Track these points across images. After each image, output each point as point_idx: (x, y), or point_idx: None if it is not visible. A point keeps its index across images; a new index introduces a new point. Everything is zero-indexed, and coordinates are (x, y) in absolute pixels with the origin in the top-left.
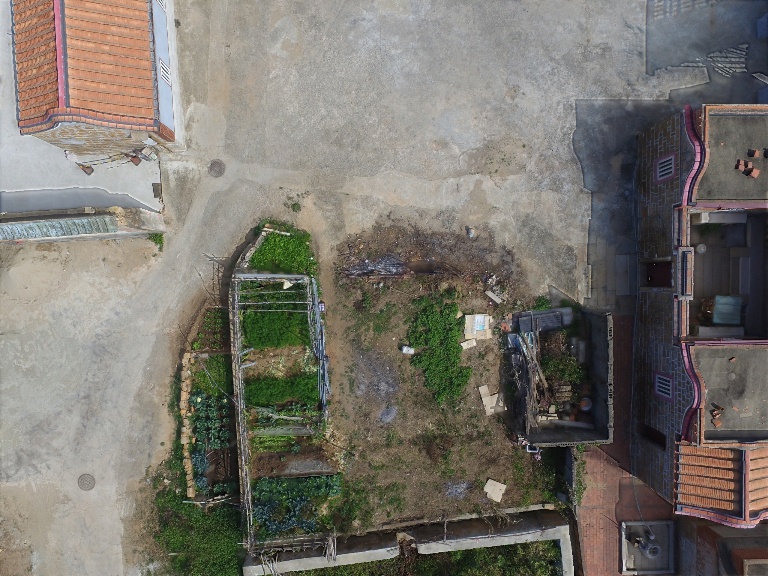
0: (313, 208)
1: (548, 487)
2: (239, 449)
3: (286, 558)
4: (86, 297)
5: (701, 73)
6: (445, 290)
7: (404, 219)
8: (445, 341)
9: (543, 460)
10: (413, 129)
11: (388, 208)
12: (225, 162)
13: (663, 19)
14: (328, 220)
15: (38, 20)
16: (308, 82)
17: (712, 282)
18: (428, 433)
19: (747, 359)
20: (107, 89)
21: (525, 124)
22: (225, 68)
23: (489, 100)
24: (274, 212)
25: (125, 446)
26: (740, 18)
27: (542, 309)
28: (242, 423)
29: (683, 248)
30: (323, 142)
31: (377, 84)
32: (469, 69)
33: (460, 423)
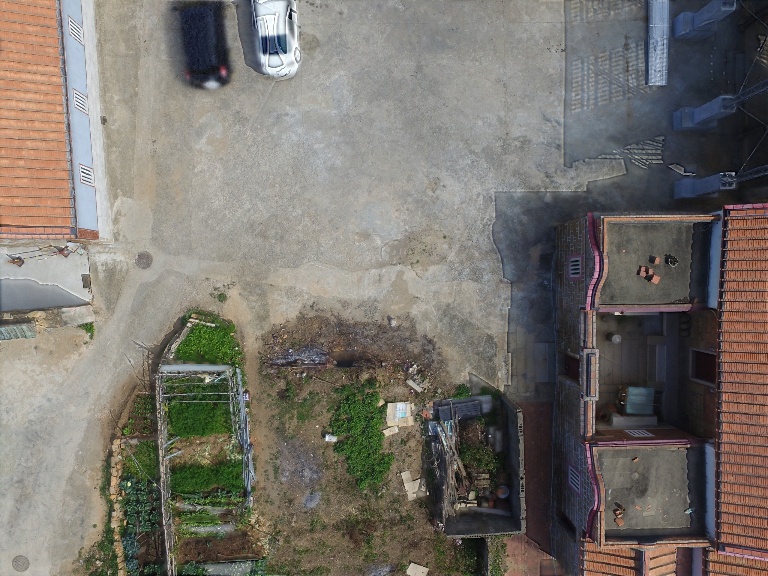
0: (238, 298)
1: (470, 570)
2: (167, 534)
3: None
4: (19, 384)
5: (618, 165)
6: (366, 380)
7: (327, 309)
8: (367, 430)
9: (465, 543)
10: (336, 221)
11: (311, 299)
12: (152, 254)
13: (581, 112)
14: (253, 310)
15: None
16: (233, 176)
17: (630, 369)
18: (351, 518)
19: (650, 459)
20: (22, 202)
21: (445, 216)
22: (151, 163)
23: (410, 192)
24: (201, 302)
25: (58, 528)
26: (656, 111)
27: (462, 397)
28: None
29: (588, 350)
30: (248, 234)
31: (300, 177)
32: (390, 162)
33: (383, 508)
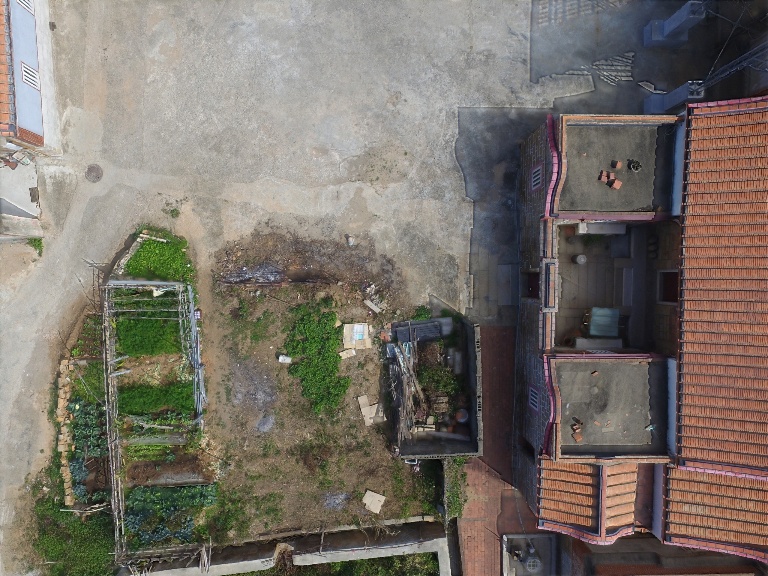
0: (191, 214)
1: (428, 499)
2: (114, 458)
3: (160, 568)
4: None
5: (586, 81)
6: (322, 299)
7: (283, 226)
8: (322, 350)
9: (423, 471)
10: (293, 135)
11: (267, 215)
12: (102, 167)
13: (548, 26)
14: (206, 227)
15: None
16: (186, 87)
17: (596, 293)
18: (306, 443)
19: (610, 373)
20: None
21: (407, 131)
22: (102, 72)
23: (370, 107)
24: (153, 218)
25: (4, 453)
26: (626, 26)
27: (421, 319)
28: (114, 432)
29: (547, 260)
30: (202, 148)
31: (257, 89)
32: (350, 75)
33: (339, 433)
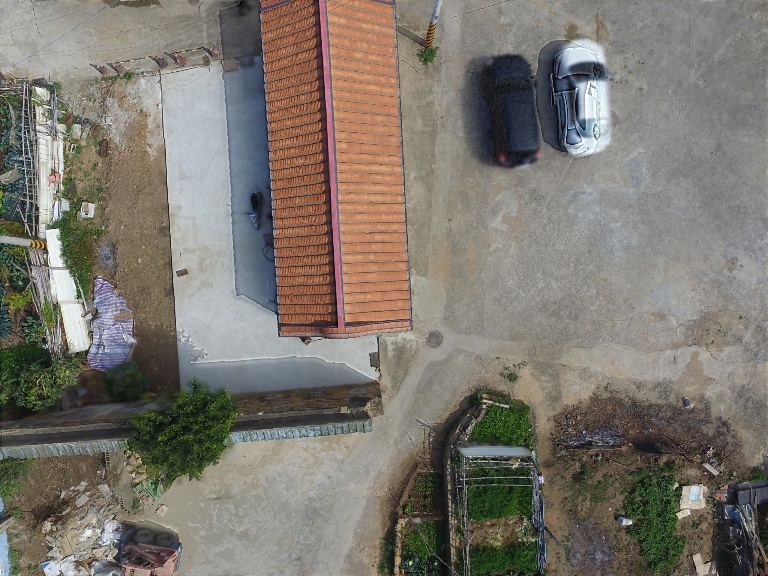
0: (530, 378)
1: None
2: None
3: None
4: (299, 462)
5: None
6: (664, 463)
7: (621, 391)
8: (663, 513)
9: None
10: (631, 301)
11: (606, 380)
12: (443, 333)
13: None
14: (545, 391)
15: (306, 230)
16: (527, 254)
17: None
18: None
19: None
20: (372, 298)
21: (742, 296)
22: (446, 242)
23: (707, 272)
24: (490, 381)
25: None
26: None
27: (758, 481)
28: None
29: None
30: (541, 314)
31: (596, 256)
32: (688, 241)
33: None
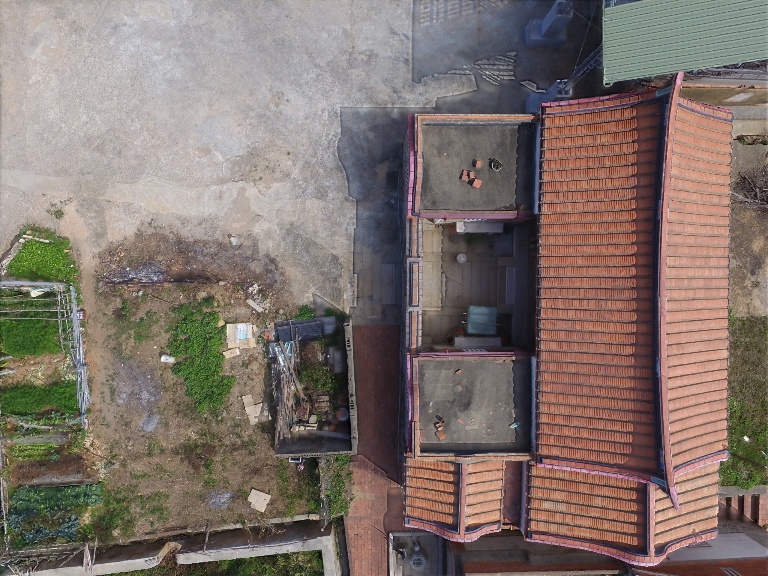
0: (75, 215)
1: (313, 497)
2: None
3: (45, 567)
4: None
5: (468, 81)
6: (204, 299)
7: (166, 227)
8: (204, 350)
9: (308, 470)
10: (175, 136)
11: (150, 215)
12: None
13: (430, 26)
14: (90, 227)
15: None
16: (69, 88)
17: (480, 292)
18: (190, 442)
19: (474, 371)
20: None
21: (289, 131)
22: None
23: (253, 107)
24: (37, 219)
25: None
26: (508, 25)
27: (304, 318)
28: None
29: (411, 259)
30: (85, 148)
31: (139, 90)
32: (232, 75)
33: (223, 432)
